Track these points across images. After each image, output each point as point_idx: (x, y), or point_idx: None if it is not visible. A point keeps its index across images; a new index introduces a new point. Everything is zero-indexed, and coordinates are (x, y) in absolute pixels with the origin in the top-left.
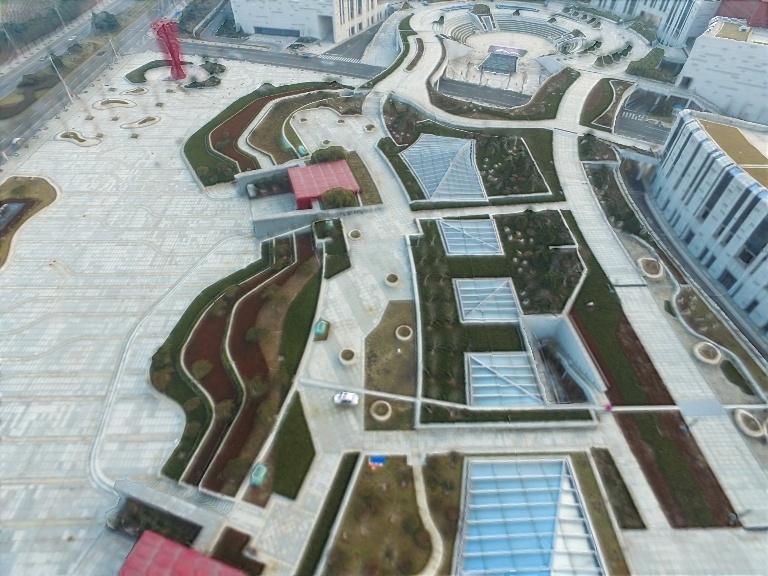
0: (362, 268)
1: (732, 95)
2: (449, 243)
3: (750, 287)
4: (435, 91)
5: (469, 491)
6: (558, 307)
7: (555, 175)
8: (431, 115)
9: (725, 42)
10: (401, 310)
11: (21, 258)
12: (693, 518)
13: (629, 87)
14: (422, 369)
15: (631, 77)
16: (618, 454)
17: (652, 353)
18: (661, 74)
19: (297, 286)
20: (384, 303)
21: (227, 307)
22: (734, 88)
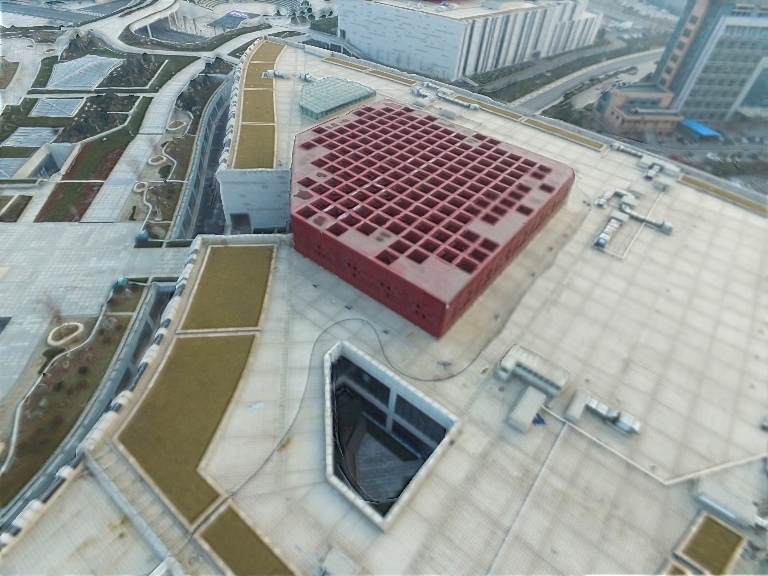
0: None
1: (370, 43)
2: (35, 110)
3: None
4: (128, 31)
5: None
6: (78, 140)
7: (167, 80)
8: (110, 45)
9: (353, 1)
10: None
11: None
12: (50, 218)
13: (296, 36)
14: None
15: (311, 31)
16: (37, 198)
17: (121, 161)
18: (329, 28)
19: None
20: None
21: None
22: (369, 37)
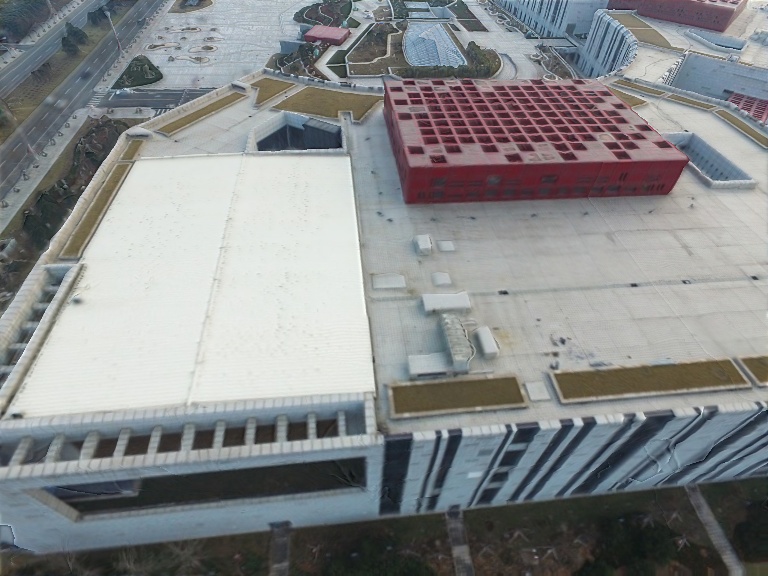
0: (367, 0)
1: None
2: None
3: (520, 8)
4: None
5: (410, 25)
6: None
7: None
8: None
9: None
10: (385, 7)
11: (218, 2)
12: (475, 30)
13: None
14: (394, 13)
15: None
16: None
17: (475, 14)
18: None
19: (342, 4)
20: (378, 6)
21: (317, 7)
22: None
